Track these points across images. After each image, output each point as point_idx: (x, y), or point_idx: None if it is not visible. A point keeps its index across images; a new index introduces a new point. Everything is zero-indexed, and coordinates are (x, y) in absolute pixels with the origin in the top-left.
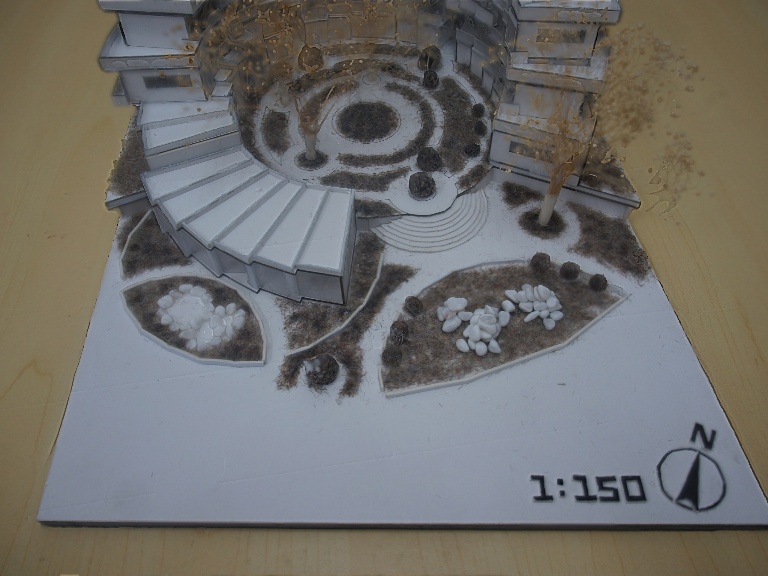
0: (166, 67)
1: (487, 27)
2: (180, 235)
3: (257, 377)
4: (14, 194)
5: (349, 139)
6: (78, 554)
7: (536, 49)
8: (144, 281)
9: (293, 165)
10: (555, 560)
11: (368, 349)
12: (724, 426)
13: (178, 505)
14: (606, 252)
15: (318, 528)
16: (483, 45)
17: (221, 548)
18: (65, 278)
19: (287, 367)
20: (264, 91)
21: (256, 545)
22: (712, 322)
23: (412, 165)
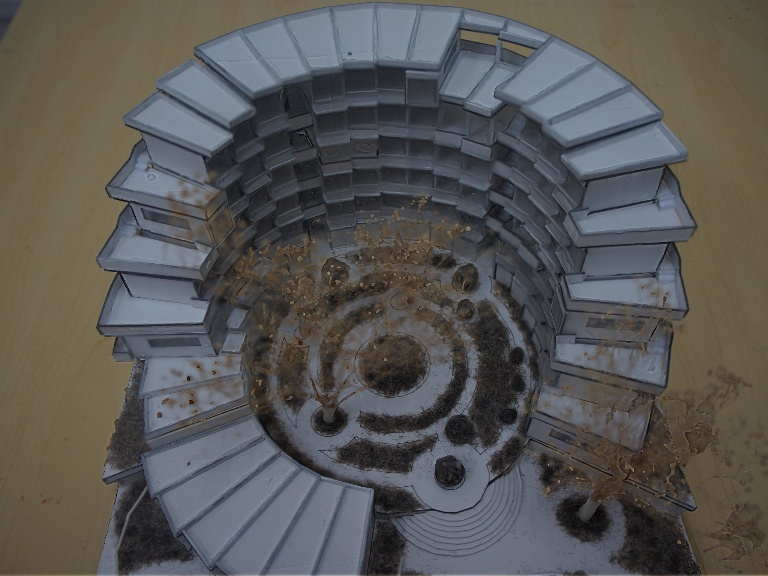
0: (172, 333)
1: (531, 269)
2: (180, 539)
3: None
4: (11, 437)
5: (372, 390)
6: None
7: (585, 332)
8: None
9: (309, 428)
10: None
11: None
12: None
13: None
14: (654, 566)
15: None
16: (525, 280)
17: None
18: (58, 562)
19: None
20: (282, 315)
21: None
22: None
23: (440, 432)
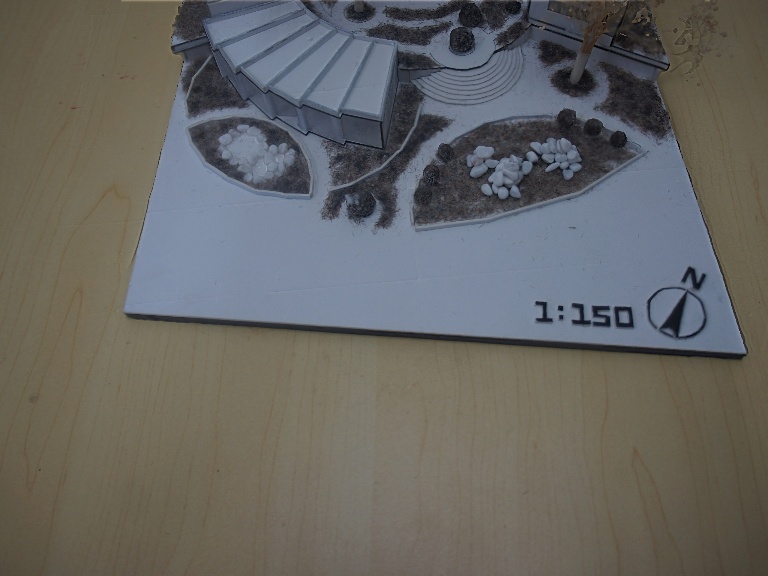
0: None
1: None
2: (238, 79)
3: (304, 208)
4: (89, 36)
5: None
6: (157, 341)
7: None
8: (207, 120)
9: (342, 17)
10: (549, 370)
11: (402, 189)
12: (714, 271)
13: (237, 307)
14: (630, 111)
15: (352, 333)
16: None
17: (272, 343)
18: (137, 115)
19: (331, 201)
20: None
21: (300, 343)
22: (722, 181)
23: (454, 20)
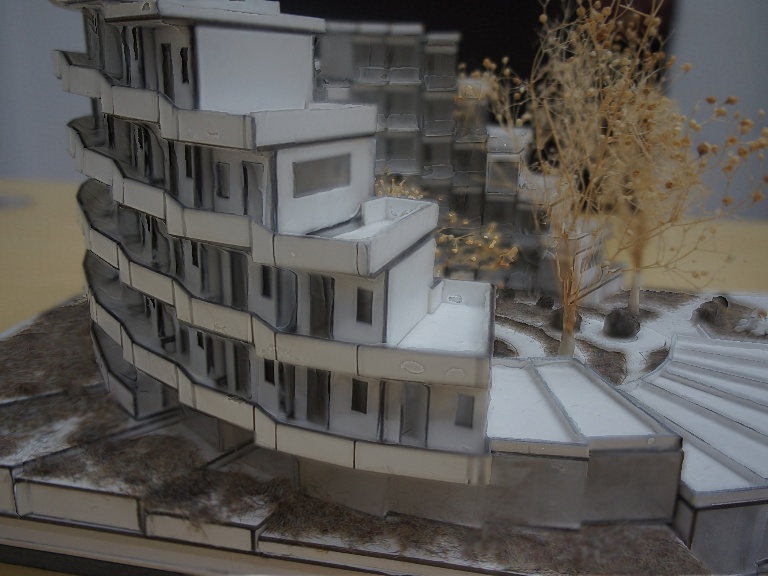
0: None
1: None
2: None
3: None
4: None
5: None
6: None
7: None
8: None
9: None
10: None
11: None
12: None
13: None
14: (671, 300)
15: None
16: None
17: None
18: None
19: None
20: None
21: None
22: None
23: None
